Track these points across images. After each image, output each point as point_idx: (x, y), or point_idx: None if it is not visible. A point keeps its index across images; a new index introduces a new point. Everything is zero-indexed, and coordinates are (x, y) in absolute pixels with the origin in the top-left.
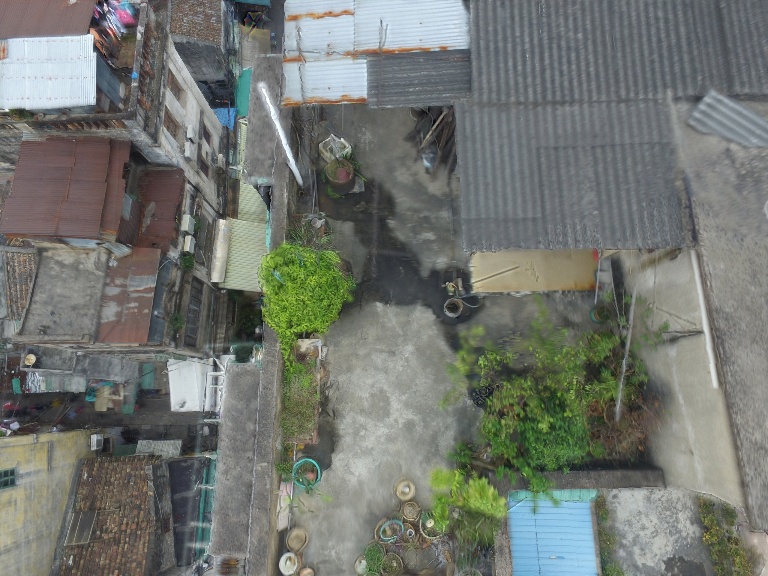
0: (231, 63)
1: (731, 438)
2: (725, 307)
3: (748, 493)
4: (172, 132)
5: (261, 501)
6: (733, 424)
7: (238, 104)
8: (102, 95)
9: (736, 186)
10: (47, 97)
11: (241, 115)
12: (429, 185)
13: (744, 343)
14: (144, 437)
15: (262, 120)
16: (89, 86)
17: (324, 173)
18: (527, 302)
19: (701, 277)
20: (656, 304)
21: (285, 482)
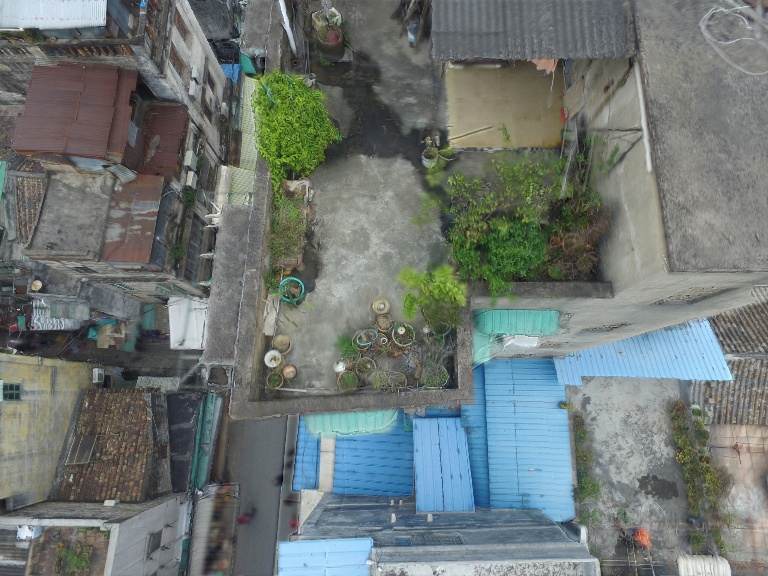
0: (236, 21)
1: (658, 204)
2: (659, 99)
3: (669, 243)
4: (177, 70)
5: (250, 300)
6: (660, 190)
7: (242, 61)
8: (112, 21)
9: (675, 5)
10: (60, 18)
11: (245, 71)
12: (412, 57)
13: (674, 128)
14: None
15: (261, 0)
16: (100, 8)
17: (316, 38)
18: (498, 157)
19: (642, 83)
20: (610, 136)
21: (272, 296)
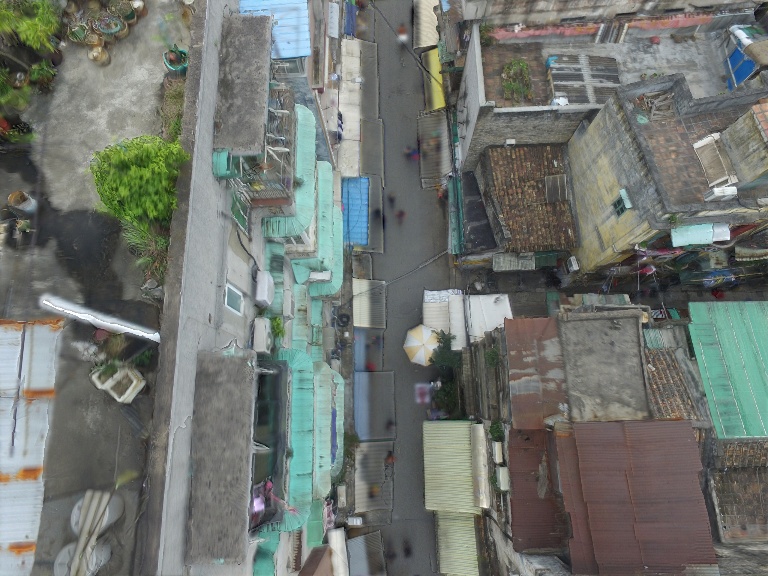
0: None
1: None
2: None
3: None
4: None
5: (198, 22)
6: None
7: None
8: None
9: None
10: None
11: None
12: None
13: None
14: (540, 281)
15: (230, 443)
16: None
17: None
18: None
19: None
20: None
21: None
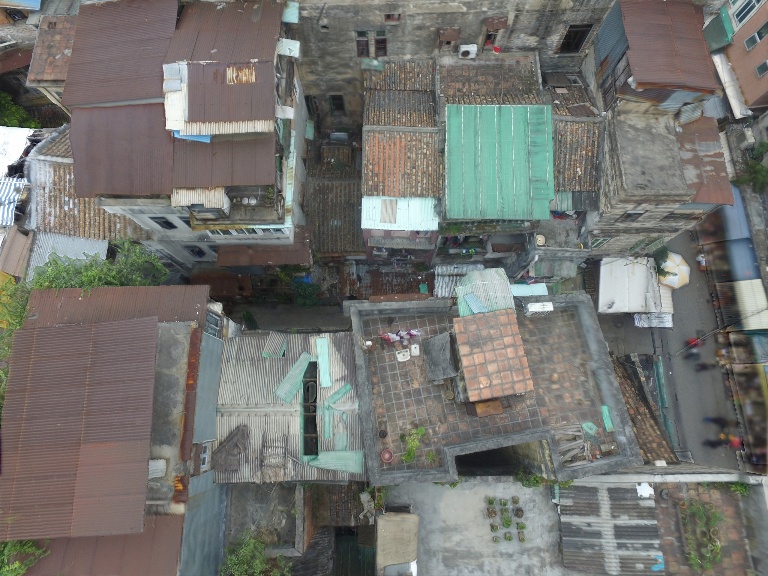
0: None
1: None
2: None
3: None
4: None
5: None
6: None
7: None
8: None
9: None
10: None
11: None
12: None
13: None
14: None
15: None
16: None
17: None
18: None
19: None
20: None
21: None
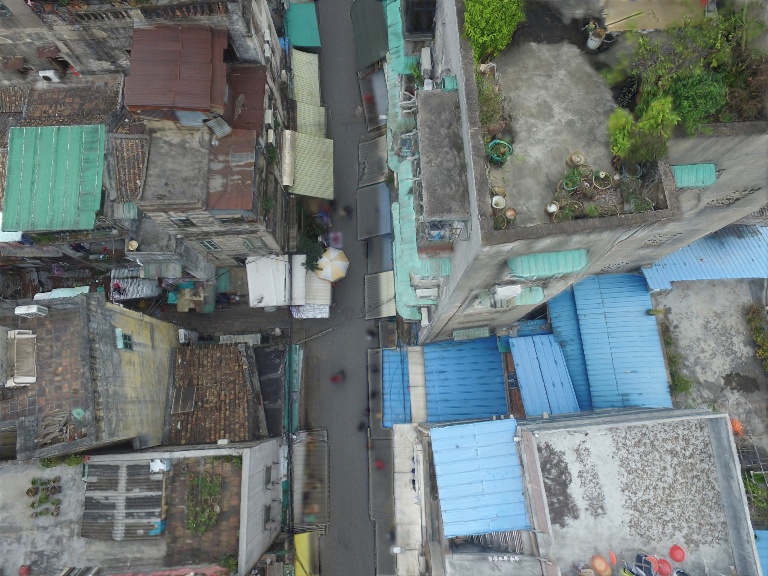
0: None
1: None
2: None
3: None
4: None
5: (478, 151)
6: None
7: (289, 34)
8: None
9: None
10: None
11: (292, 44)
12: None
13: None
14: None
15: None
16: None
17: None
18: (651, 37)
19: None
20: None
21: None
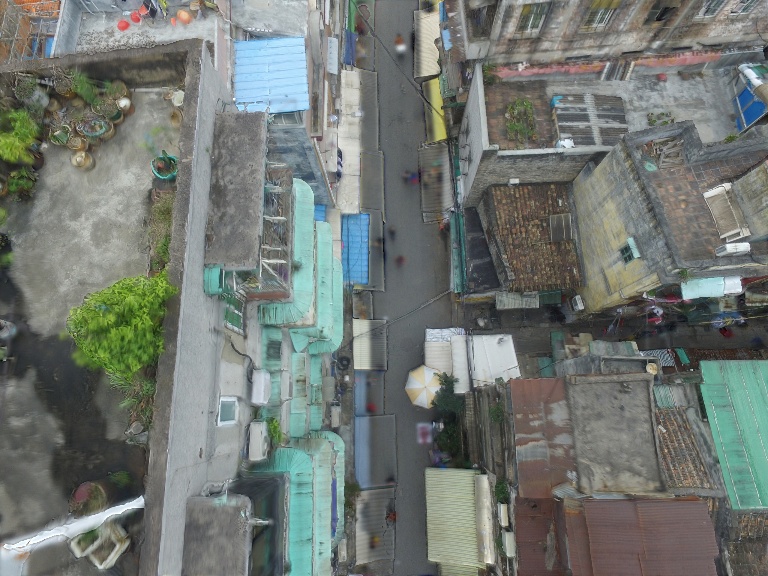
0: None
1: None
2: None
3: None
4: None
5: (188, 132)
6: None
7: None
8: None
9: None
10: None
11: None
12: None
13: None
14: (544, 316)
15: None
16: None
17: None
18: None
19: None
20: None
21: None
